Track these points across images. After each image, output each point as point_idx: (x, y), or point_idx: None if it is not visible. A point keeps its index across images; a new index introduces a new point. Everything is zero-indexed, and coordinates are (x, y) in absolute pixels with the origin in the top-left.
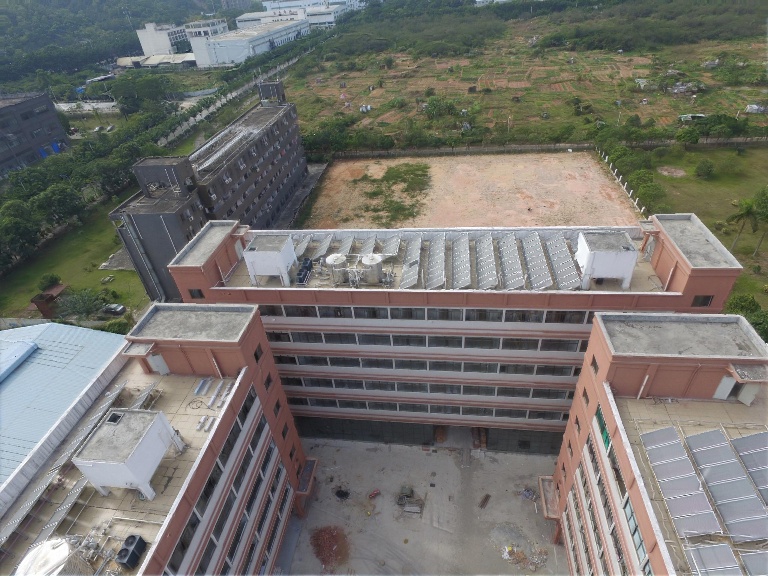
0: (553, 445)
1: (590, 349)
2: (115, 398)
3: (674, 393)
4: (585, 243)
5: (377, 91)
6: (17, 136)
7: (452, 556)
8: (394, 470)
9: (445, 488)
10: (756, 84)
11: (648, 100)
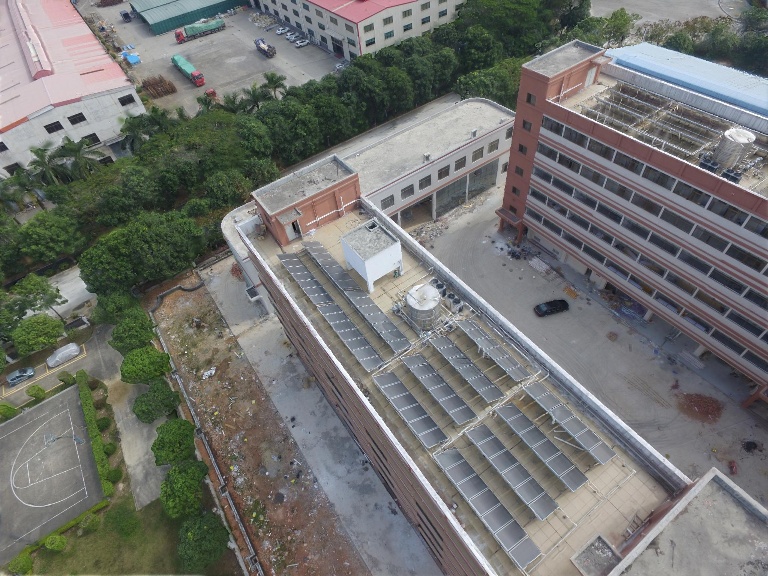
0: None
1: None
2: None
3: None
4: None
5: None
6: None
7: None
8: None
9: None
10: None
11: None
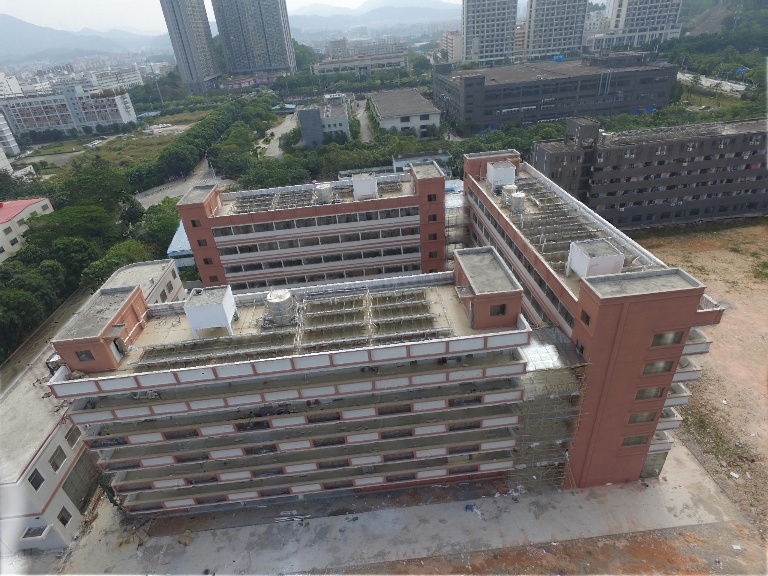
0: None
1: None
2: (391, 181)
3: None
4: None
5: None
6: (625, 94)
7: None
8: None
9: None
10: None
11: None
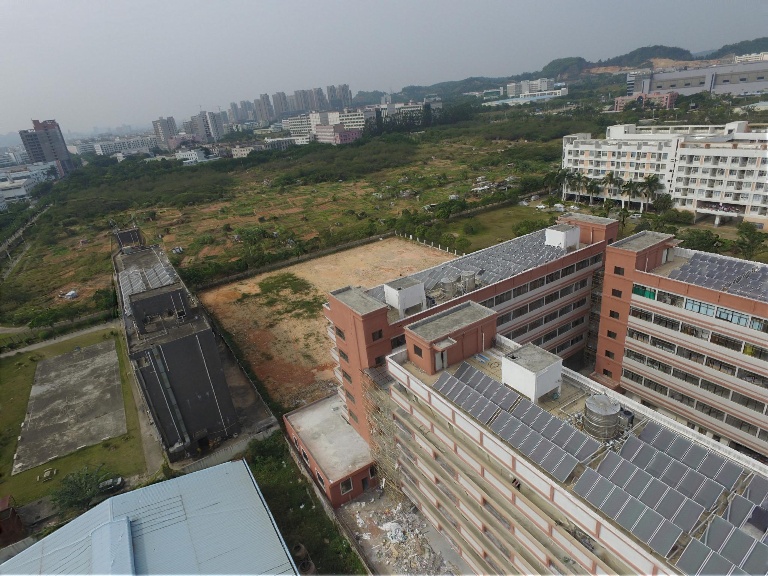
0: None
1: (610, 266)
2: None
3: (652, 267)
4: (556, 231)
5: (168, 237)
6: None
7: None
8: None
9: None
10: (439, 186)
11: (393, 203)
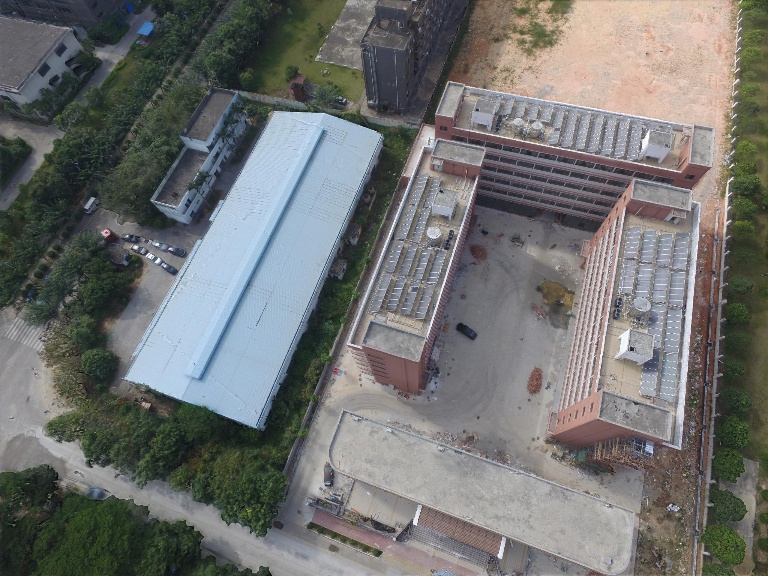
0: (596, 228)
1: (626, 192)
2: None
3: (650, 215)
4: (648, 138)
5: None
6: None
7: (533, 265)
8: (511, 226)
9: (535, 238)
10: None
11: None
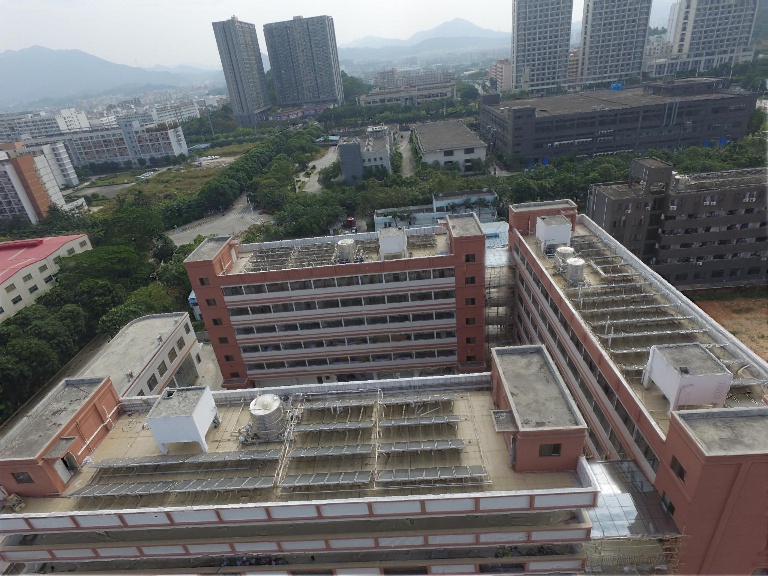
0: None
1: None
2: (424, 235)
3: None
4: None
5: None
6: (694, 125)
7: None
8: None
9: None
10: None
11: None
